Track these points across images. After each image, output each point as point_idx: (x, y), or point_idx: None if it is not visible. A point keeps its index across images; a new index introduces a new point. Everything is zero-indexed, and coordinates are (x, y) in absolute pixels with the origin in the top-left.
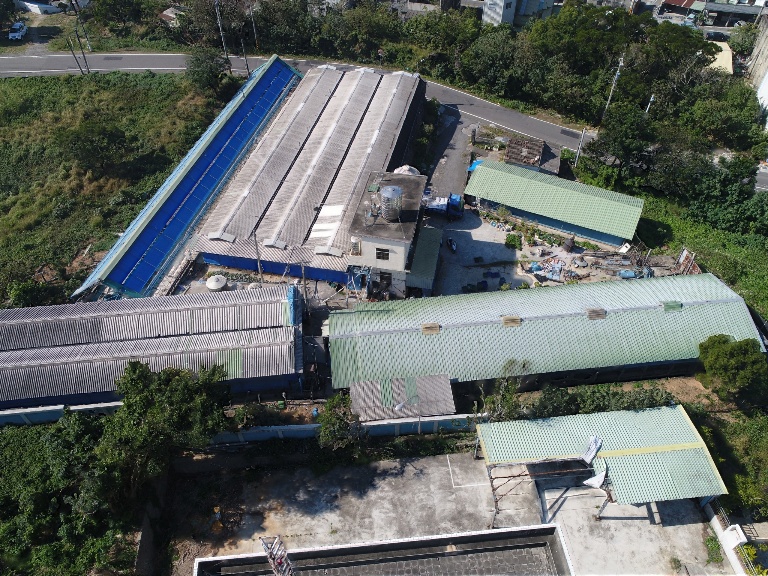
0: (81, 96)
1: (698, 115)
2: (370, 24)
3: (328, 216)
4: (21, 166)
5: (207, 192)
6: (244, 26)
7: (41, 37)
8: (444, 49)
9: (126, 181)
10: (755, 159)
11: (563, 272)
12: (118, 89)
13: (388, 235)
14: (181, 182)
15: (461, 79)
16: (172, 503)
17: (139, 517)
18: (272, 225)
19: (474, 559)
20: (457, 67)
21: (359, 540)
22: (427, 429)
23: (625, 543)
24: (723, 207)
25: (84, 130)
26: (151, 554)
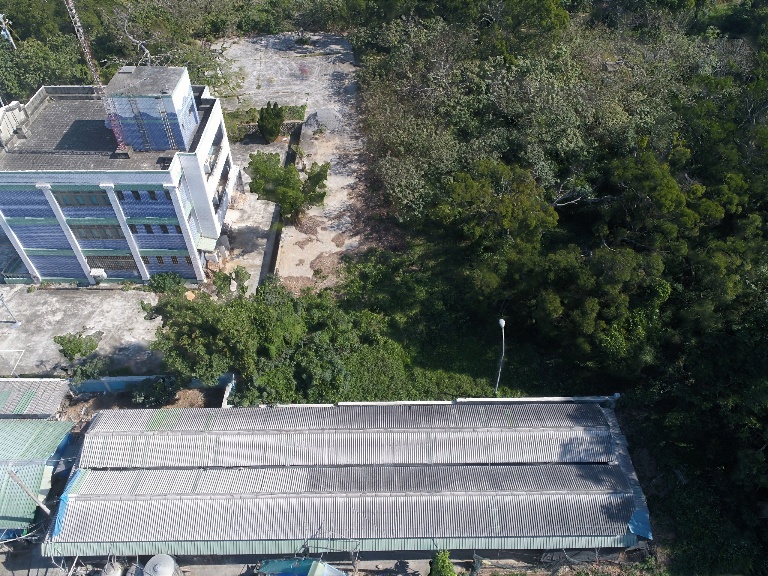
0: None
1: None
2: None
3: None
4: None
5: None
6: None
7: None
8: None
9: None
10: None
11: None
12: None
13: None
14: None
15: None
16: None
17: None
18: None
19: None
20: None
21: (115, 323)
22: None
23: None
24: None
25: None
26: None
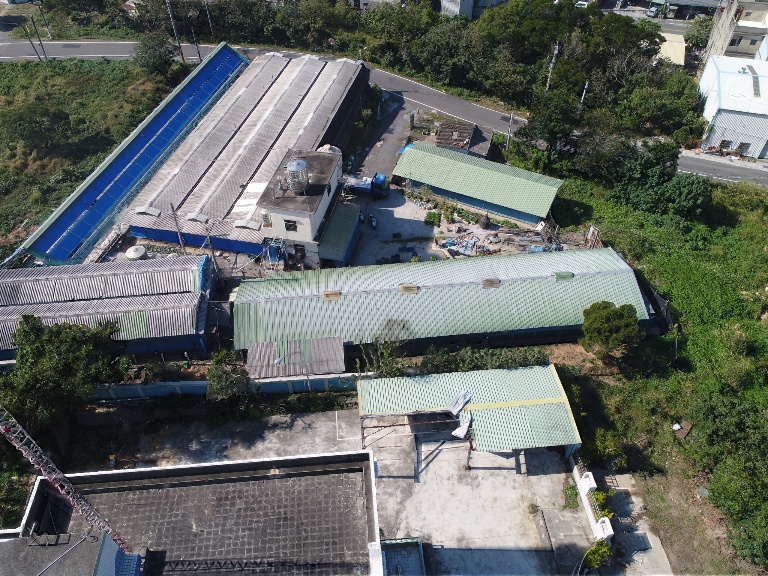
0: (35, 81)
1: (635, 102)
2: (325, 14)
3: (252, 193)
4: None
5: (141, 170)
6: (204, 16)
7: (6, 26)
8: None
9: (68, 160)
10: (676, 143)
11: (475, 247)
12: (72, 75)
13: (294, 207)
14: (115, 160)
15: (409, 67)
16: (72, 452)
17: None
18: (197, 200)
19: (296, 482)
20: (404, 55)
21: None
22: (319, 387)
23: (489, 490)
24: (644, 189)
25: (27, 111)
26: None
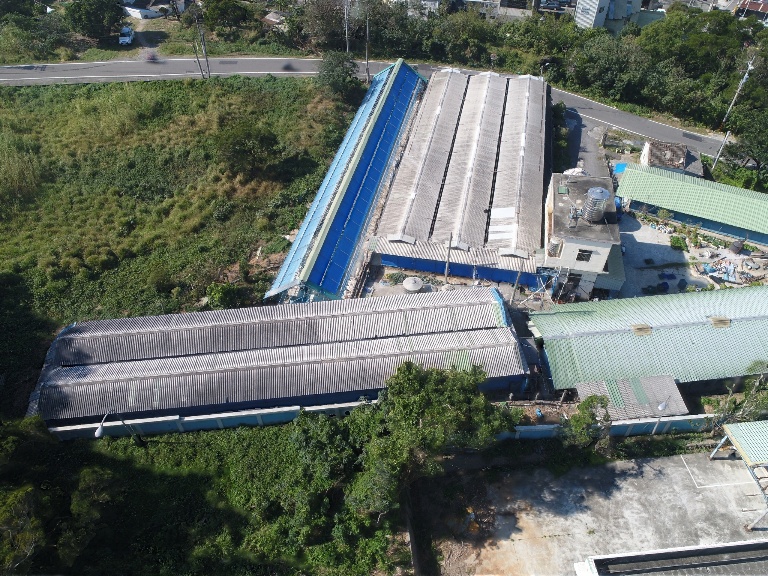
0: (210, 100)
1: None
2: (474, 28)
3: (501, 218)
4: (168, 169)
5: (371, 194)
6: None
7: (149, 41)
8: (547, 53)
9: (279, 184)
10: None
11: (738, 274)
12: (244, 93)
13: (595, 236)
14: (349, 184)
15: (573, 83)
16: (420, 504)
17: (402, 517)
18: (449, 227)
19: None
20: (572, 71)
21: (619, 540)
22: (656, 430)
23: None
24: None
25: (241, 133)
26: (416, 554)
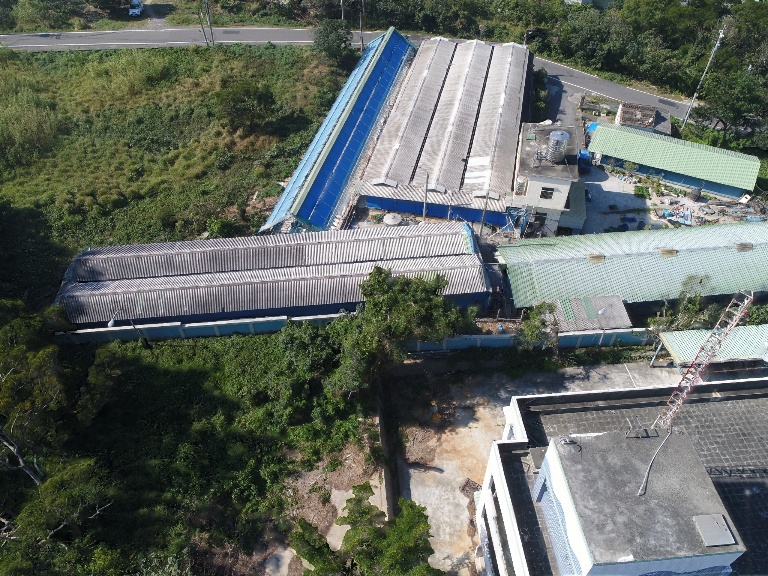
0: (213, 64)
1: None
2: (465, 2)
3: (477, 166)
4: (174, 125)
5: (359, 146)
6: None
7: (157, 13)
8: None
9: (276, 138)
10: None
11: (694, 218)
12: (245, 59)
13: (556, 175)
14: (338, 135)
15: (557, 53)
16: (390, 399)
17: (373, 405)
18: (428, 173)
19: (734, 404)
20: (556, 41)
21: None
22: (604, 342)
23: None
24: None
25: (241, 90)
26: (385, 437)
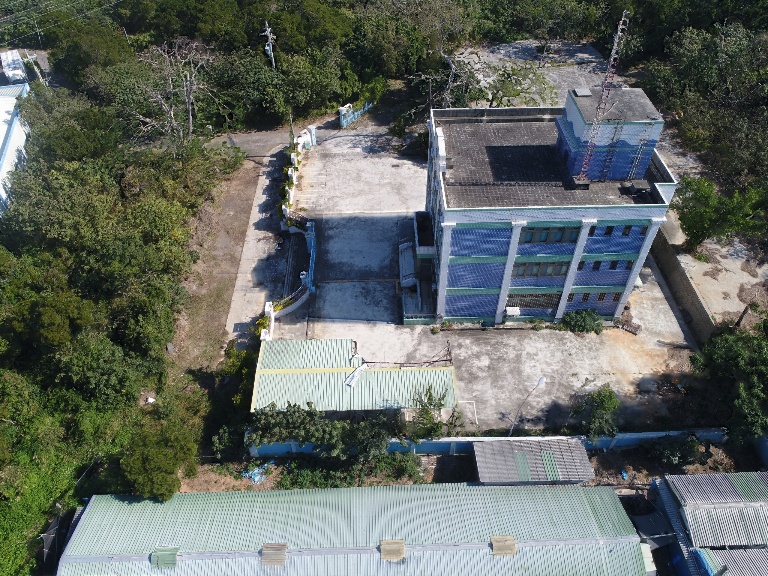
0: None
1: None
2: None
3: None
4: None
5: None
6: None
7: None
8: None
9: None
10: None
11: None
12: None
13: None
14: None
15: None
16: None
17: None
18: None
19: None
20: None
21: (553, 368)
22: None
23: None
24: None
25: None
26: None
